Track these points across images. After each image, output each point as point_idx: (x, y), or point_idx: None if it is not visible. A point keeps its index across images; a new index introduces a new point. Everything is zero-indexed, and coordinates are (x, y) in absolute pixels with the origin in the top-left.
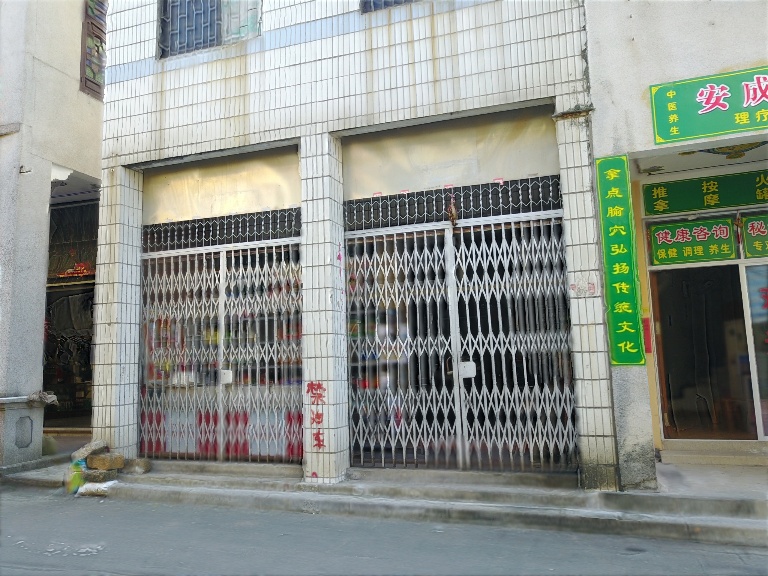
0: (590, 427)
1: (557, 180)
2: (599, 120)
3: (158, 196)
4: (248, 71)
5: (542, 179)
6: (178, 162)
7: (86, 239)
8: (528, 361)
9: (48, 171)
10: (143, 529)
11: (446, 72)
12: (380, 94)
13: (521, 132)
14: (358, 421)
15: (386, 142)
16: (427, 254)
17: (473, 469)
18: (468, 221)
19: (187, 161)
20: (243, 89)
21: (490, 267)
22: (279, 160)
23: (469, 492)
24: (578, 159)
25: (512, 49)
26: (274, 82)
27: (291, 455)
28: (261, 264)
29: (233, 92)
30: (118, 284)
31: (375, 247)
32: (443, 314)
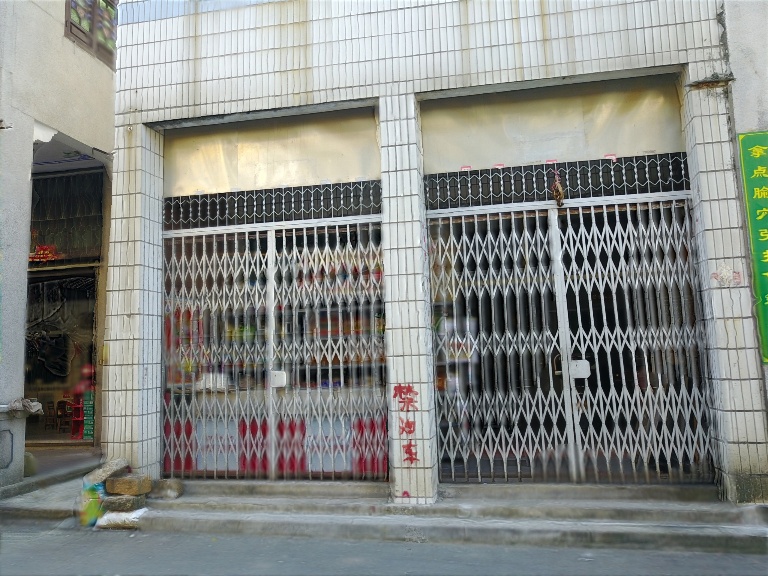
0: (741, 433)
1: (678, 158)
2: (741, 91)
3: (184, 163)
4: (310, 17)
5: (661, 157)
6: (215, 122)
7: (52, 218)
8: (650, 359)
9: (30, 129)
10: (225, 574)
11: (558, 30)
12: (478, 52)
13: (636, 104)
14: (447, 429)
15: (476, 109)
16: (527, 238)
17: (589, 482)
18: (576, 201)
19: (227, 121)
20: (304, 38)
21: (602, 253)
22: (342, 125)
23: (601, 510)
24: (717, 134)
25: (636, 8)
26: (344, 32)
27: (364, 471)
28: (321, 246)
29: (291, 41)
30: (140, 267)
31: (464, 228)
32: (549, 306)
